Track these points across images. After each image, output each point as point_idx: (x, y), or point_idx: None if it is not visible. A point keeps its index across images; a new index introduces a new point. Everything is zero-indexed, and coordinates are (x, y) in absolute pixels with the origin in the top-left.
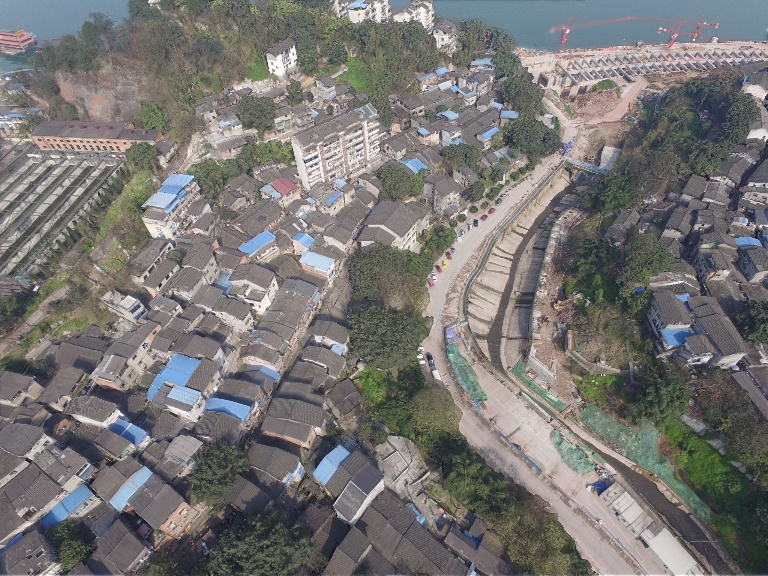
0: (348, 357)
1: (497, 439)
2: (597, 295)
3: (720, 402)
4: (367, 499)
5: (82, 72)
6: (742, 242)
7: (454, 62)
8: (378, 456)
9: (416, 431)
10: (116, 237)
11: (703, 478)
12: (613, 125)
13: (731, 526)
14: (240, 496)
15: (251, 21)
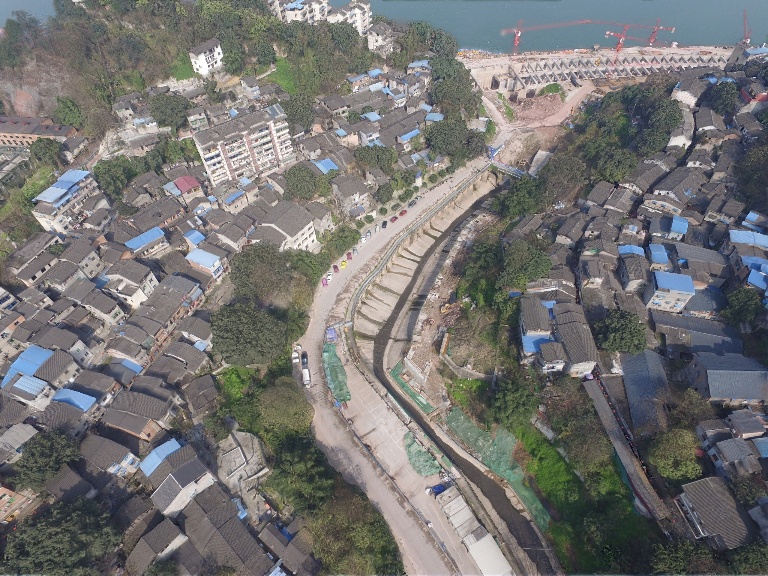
0: (215, 353)
1: (350, 439)
2: (477, 299)
3: None
4: (187, 492)
5: (8, 68)
6: (625, 250)
7: (388, 64)
8: (220, 451)
9: (264, 428)
10: (3, 230)
11: (548, 486)
12: (550, 129)
13: (566, 535)
14: (59, 484)
15: (175, 21)
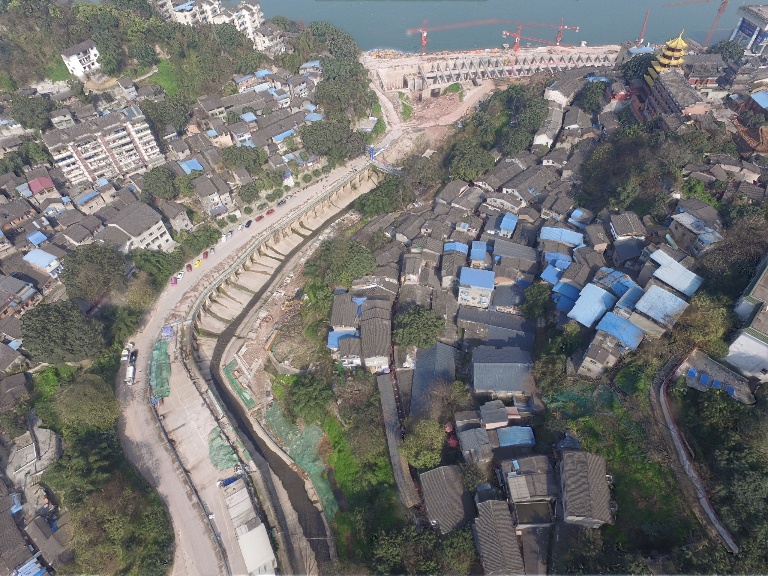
0: None
1: (157, 434)
2: None
3: (353, 403)
4: None
5: None
6: (449, 247)
7: (276, 64)
8: (14, 447)
9: None
10: None
11: (342, 477)
12: (440, 128)
13: (348, 524)
14: None
15: (47, 23)
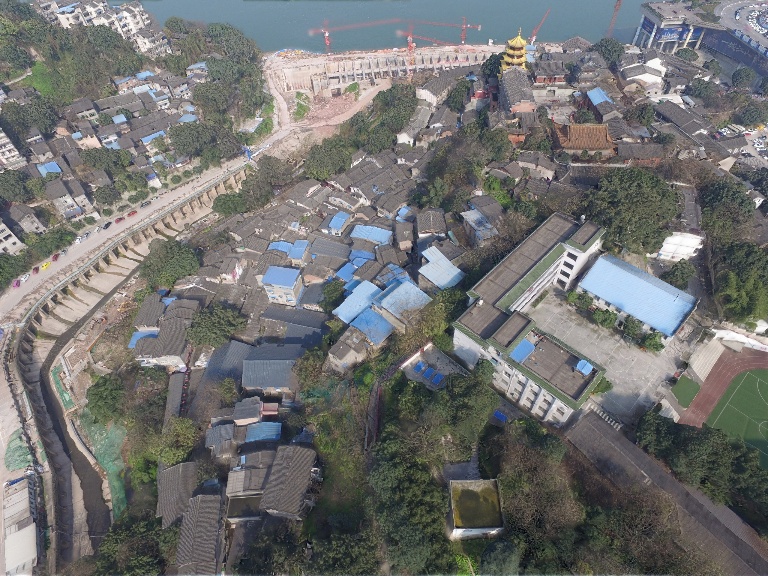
0: None
1: None
2: None
3: None
4: None
5: None
6: (273, 247)
7: (159, 66)
8: None
9: None
10: None
11: None
12: (328, 128)
13: None
14: None
15: None
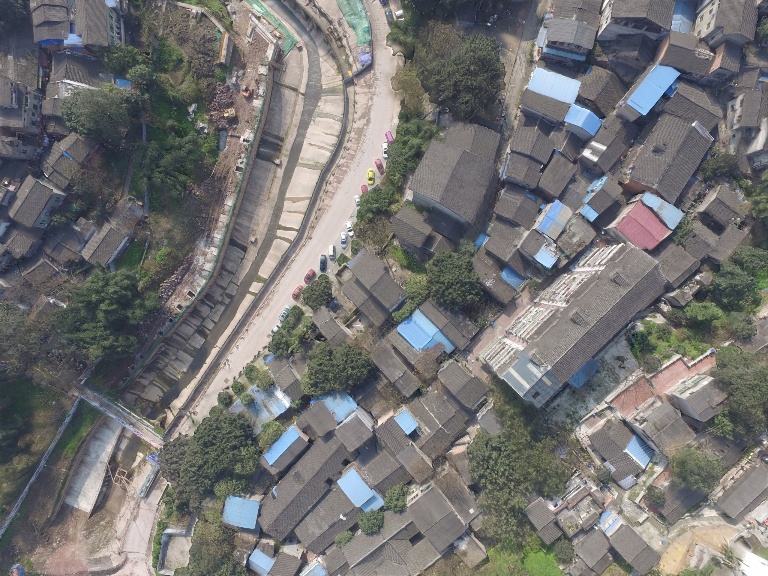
0: None
1: None
2: None
3: None
4: None
5: None
6: None
7: None
8: None
9: None
10: None
11: None
12: (59, 566)
13: None
14: None
15: None
